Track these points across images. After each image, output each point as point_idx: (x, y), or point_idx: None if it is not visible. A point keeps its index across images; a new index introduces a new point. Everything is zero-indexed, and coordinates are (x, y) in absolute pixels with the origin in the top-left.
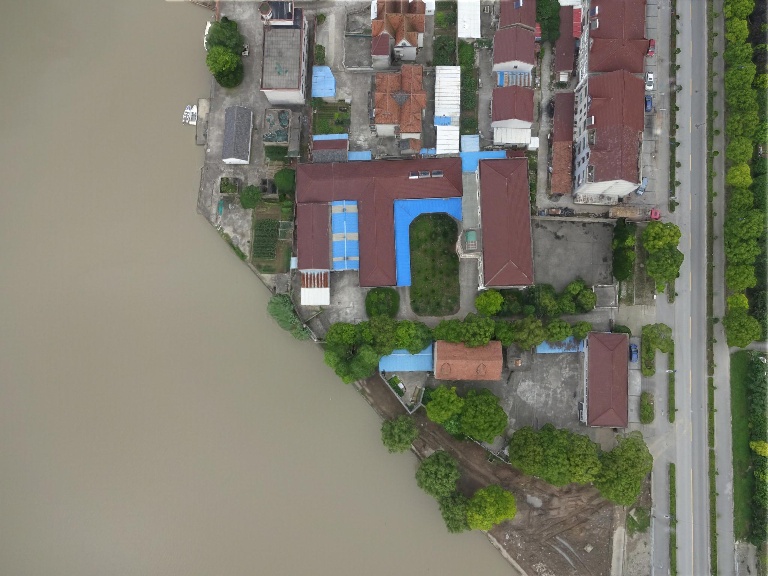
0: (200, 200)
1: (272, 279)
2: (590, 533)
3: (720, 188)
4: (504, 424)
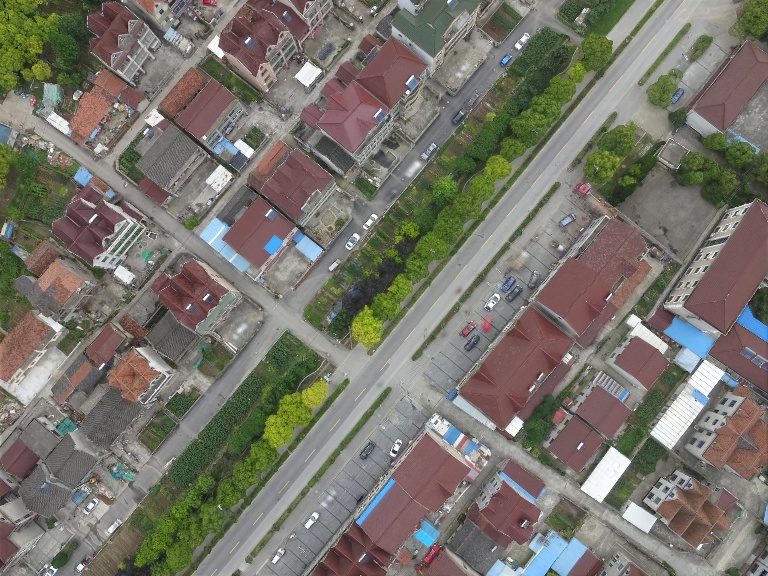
0: None
1: None
2: None
3: None
4: None
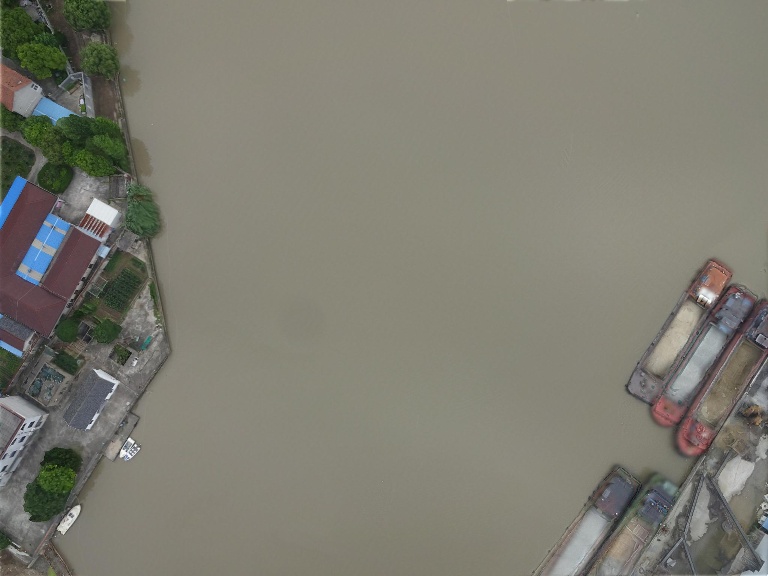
0: (162, 362)
1: (139, 253)
2: None
3: None
4: None
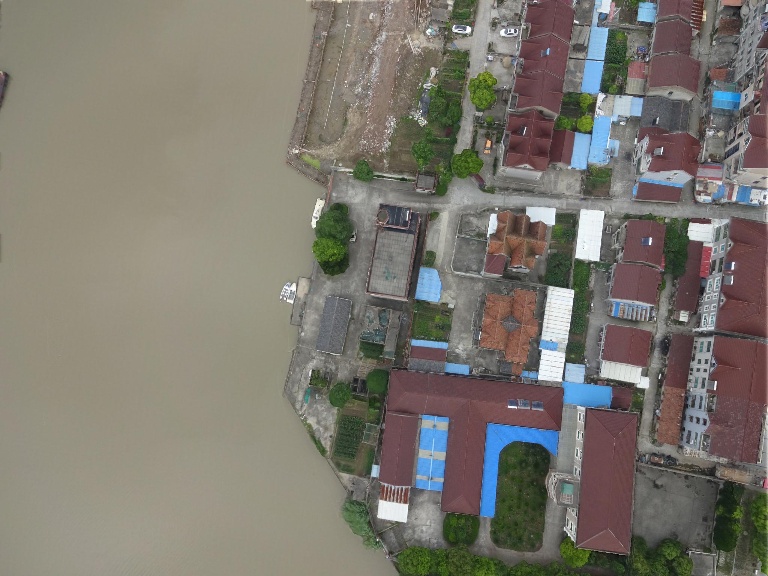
0: (287, 384)
1: (350, 480)
2: None
3: None
4: None
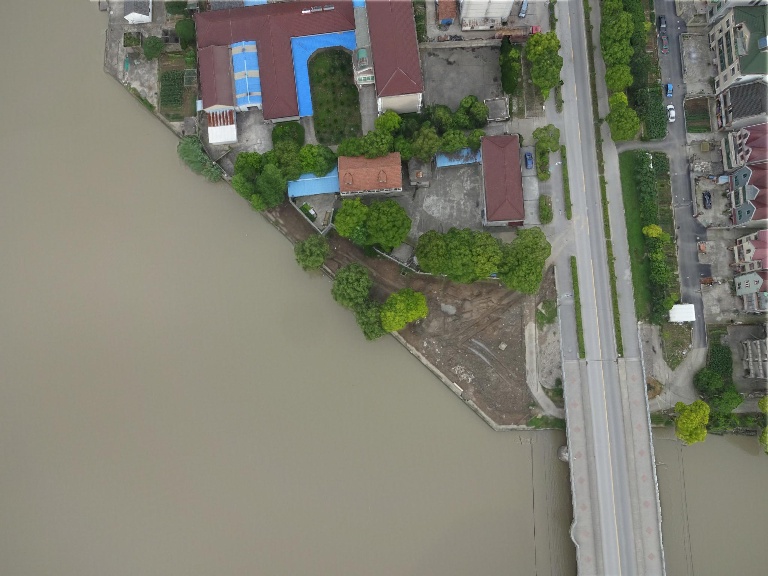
0: (106, 60)
1: (181, 126)
2: (503, 332)
3: (596, 6)
4: (407, 225)
